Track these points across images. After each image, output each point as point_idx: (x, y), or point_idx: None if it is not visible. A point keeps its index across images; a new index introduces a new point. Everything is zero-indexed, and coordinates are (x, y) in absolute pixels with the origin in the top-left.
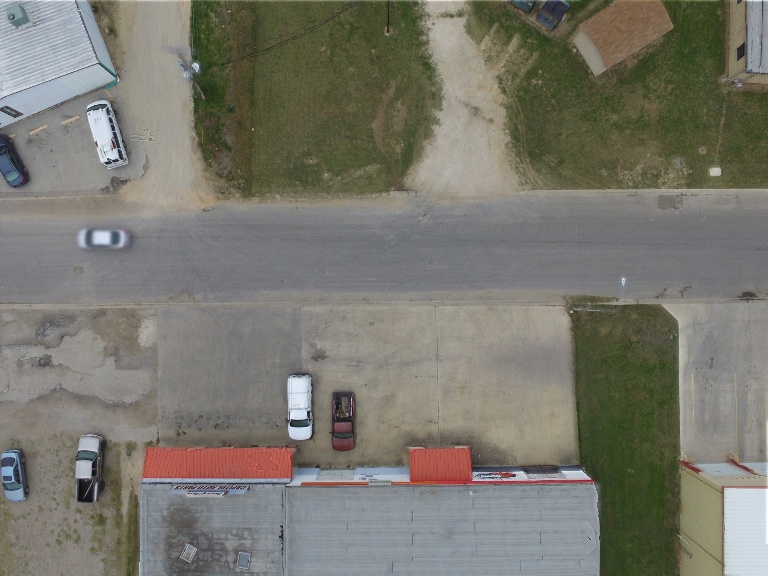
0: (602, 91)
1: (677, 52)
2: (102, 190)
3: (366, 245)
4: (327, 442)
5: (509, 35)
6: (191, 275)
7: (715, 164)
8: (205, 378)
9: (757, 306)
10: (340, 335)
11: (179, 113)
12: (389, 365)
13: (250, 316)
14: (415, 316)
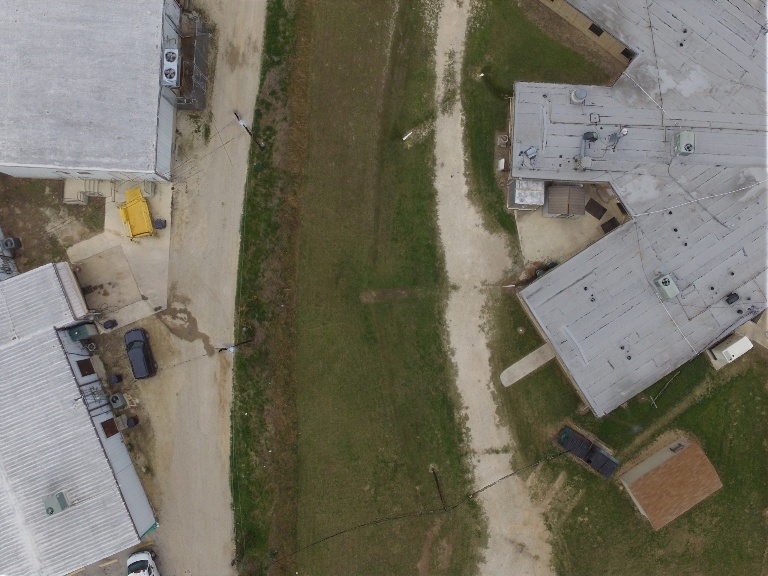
0: (648, 527)
1: (723, 484)
2: None
3: None
4: None
5: (556, 473)
6: None
7: None
8: None
9: None
10: None
11: (221, 555)
12: None
13: None
14: None
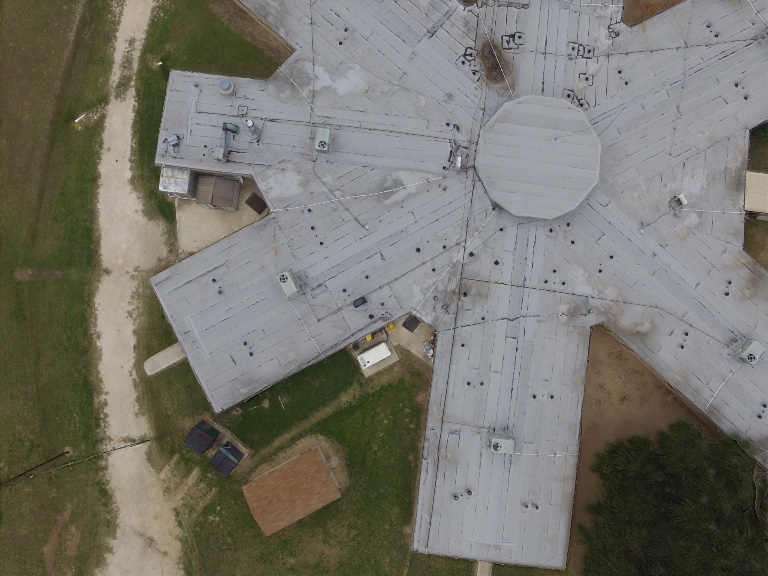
0: (281, 534)
1: (364, 496)
2: None
3: None
4: None
5: (189, 468)
6: None
7: None
8: None
9: None
10: None
11: None
12: None
13: None
14: None
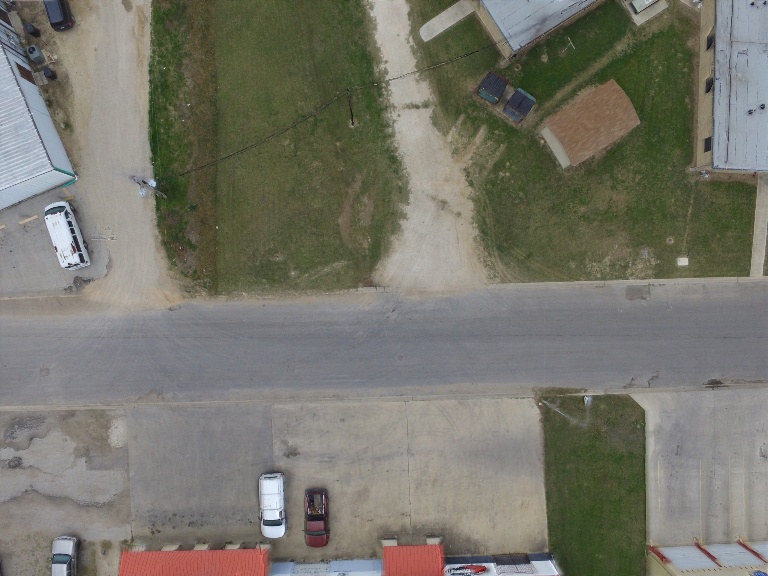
0: (570, 183)
1: (645, 141)
2: (65, 290)
3: (335, 342)
4: (300, 537)
5: (476, 127)
6: (159, 375)
7: (682, 254)
8: (177, 477)
9: (722, 393)
10: (311, 432)
11: (141, 211)
12: (360, 460)
13: (220, 415)
14: (385, 412)
